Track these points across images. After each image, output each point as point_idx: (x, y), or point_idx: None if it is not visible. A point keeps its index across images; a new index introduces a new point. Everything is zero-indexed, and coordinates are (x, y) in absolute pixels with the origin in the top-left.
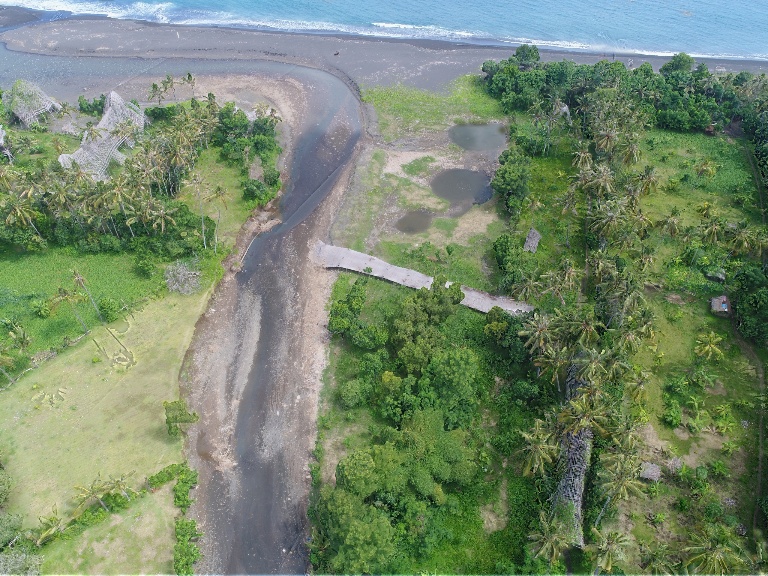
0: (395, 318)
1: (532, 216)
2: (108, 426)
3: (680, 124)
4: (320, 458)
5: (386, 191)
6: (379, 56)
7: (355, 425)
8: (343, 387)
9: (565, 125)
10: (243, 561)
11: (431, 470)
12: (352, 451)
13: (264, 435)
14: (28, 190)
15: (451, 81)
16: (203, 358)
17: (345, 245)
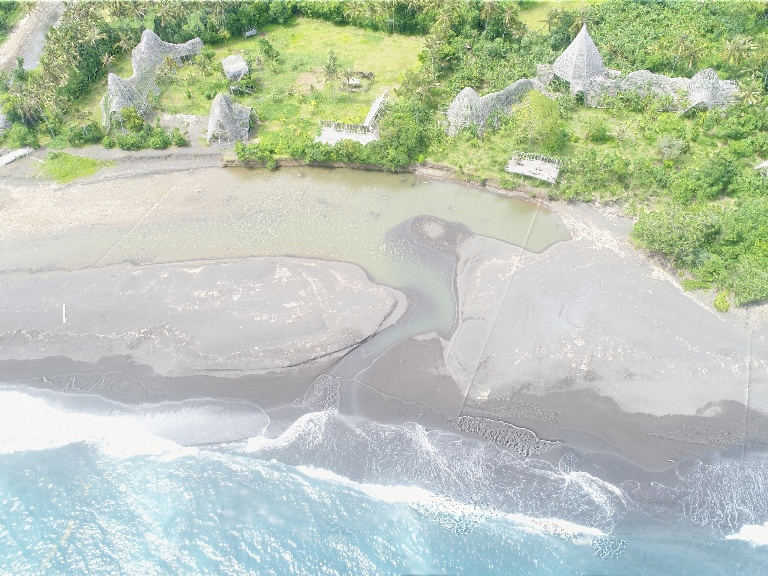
0: None
1: None
2: None
3: None
4: None
5: None
6: None
7: None
8: None
9: None
10: None
11: None
12: None
13: (60, 2)
14: None
15: None
16: None
17: None
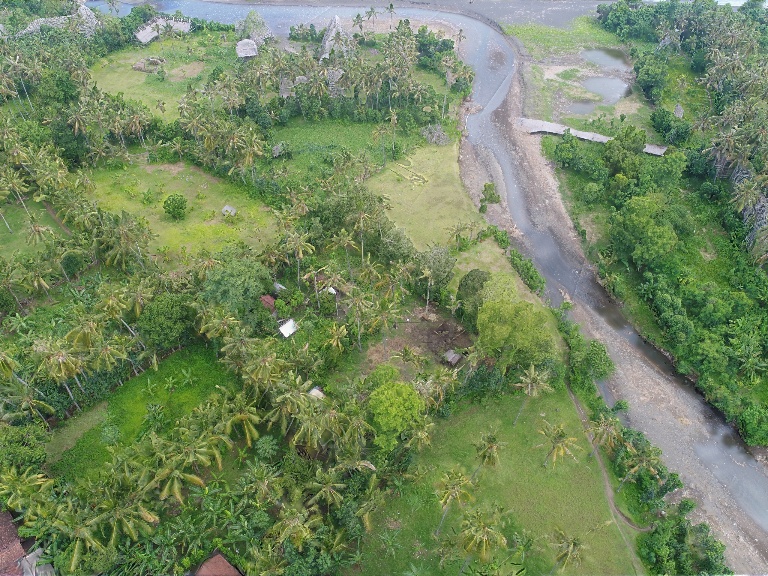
0: (596, 158)
1: (670, 102)
2: (430, 212)
3: (762, 46)
4: (580, 228)
5: (552, 89)
6: (506, 4)
7: (595, 213)
8: (585, 188)
9: (672, 48)
10: (553, 277)
11: (670, 220)
12: (600, 225)
13: (534, 219)
14: (323, 71)
15: (571, 21)
16: (469, 181)
17: (539, 119)
